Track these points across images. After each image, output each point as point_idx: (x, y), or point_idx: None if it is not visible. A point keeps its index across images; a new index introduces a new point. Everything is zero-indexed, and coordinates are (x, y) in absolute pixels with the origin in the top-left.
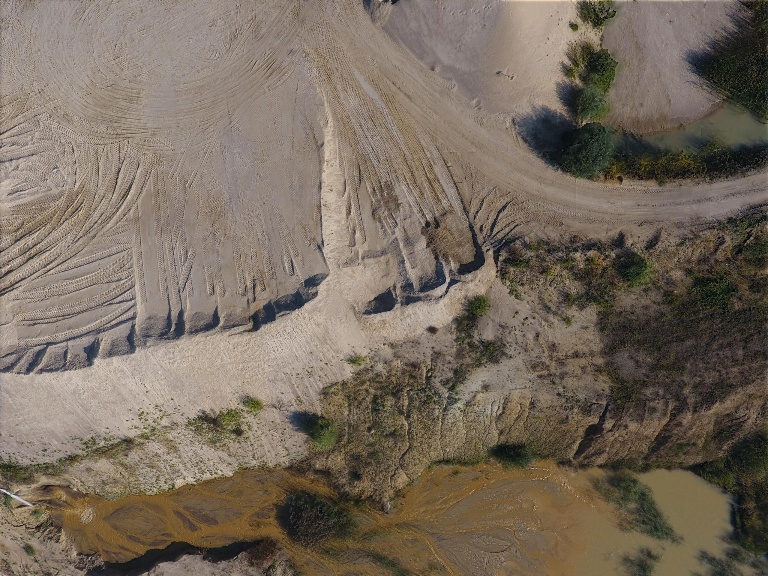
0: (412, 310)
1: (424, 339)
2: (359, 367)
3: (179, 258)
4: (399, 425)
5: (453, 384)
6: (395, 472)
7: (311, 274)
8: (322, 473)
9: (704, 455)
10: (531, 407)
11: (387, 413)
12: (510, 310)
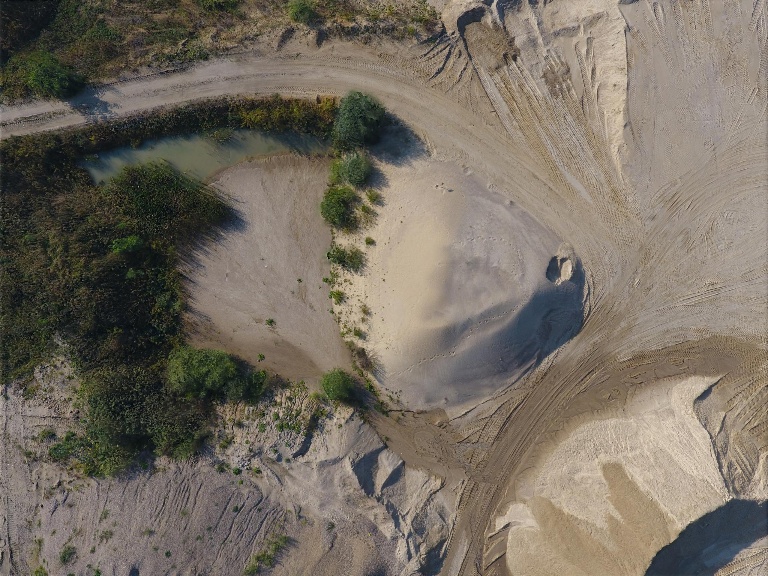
0: None
1: None
2: None
3: (765, 23)
4: None
5: None
6: None
7: (636, 4)
8: None
9: None
10: None
11: None
12: None
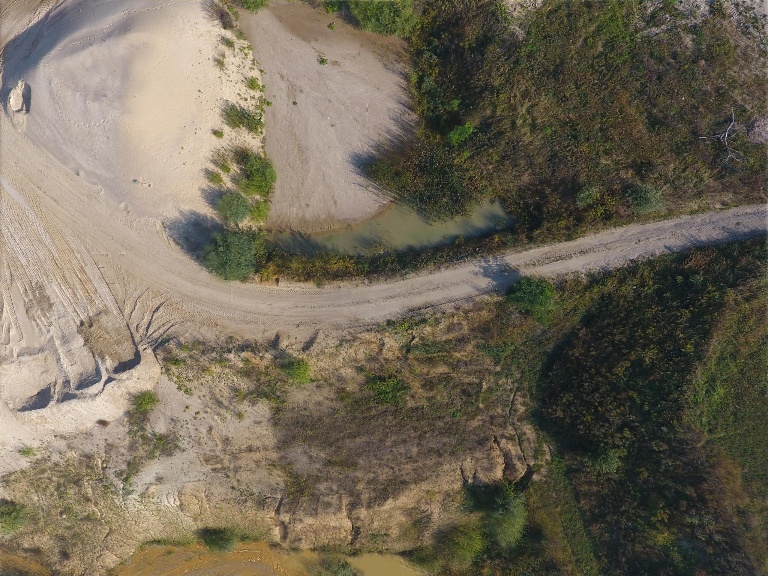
0: (69, 407)
1: (97, 431)
2: (35, 457)
3: None
4: (90, 511)
5: (127, 476)
6: (100, 553)
7: None
8: (32, 551)
9: (401, 544)
10: (208, 499)
11: (72, 500)
12: (180, 405)
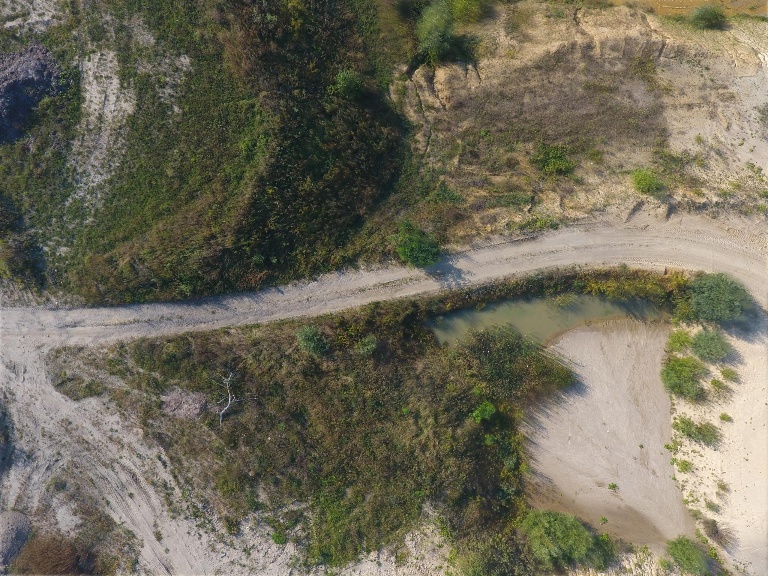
0: None
1: None
2: None
3: None
4: None
5: None
6: None
7: None
8: None
9: (531, 7)
10: None
11: None
12: (759, 153)
